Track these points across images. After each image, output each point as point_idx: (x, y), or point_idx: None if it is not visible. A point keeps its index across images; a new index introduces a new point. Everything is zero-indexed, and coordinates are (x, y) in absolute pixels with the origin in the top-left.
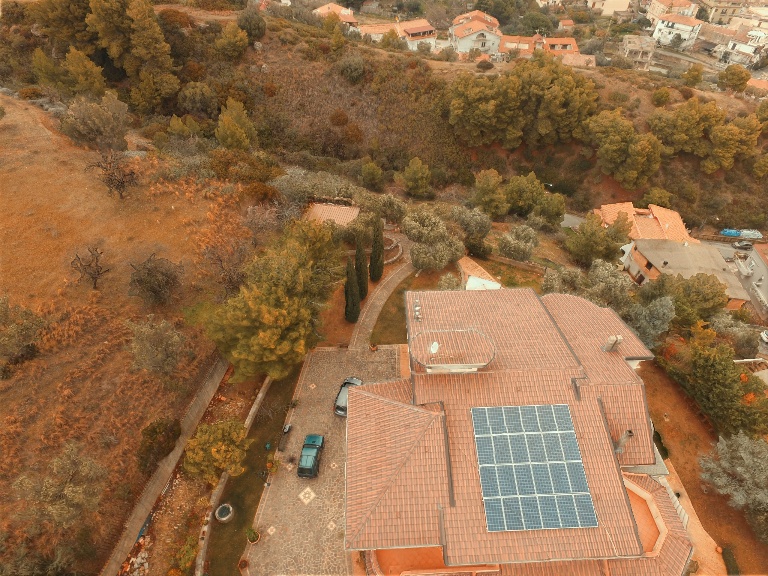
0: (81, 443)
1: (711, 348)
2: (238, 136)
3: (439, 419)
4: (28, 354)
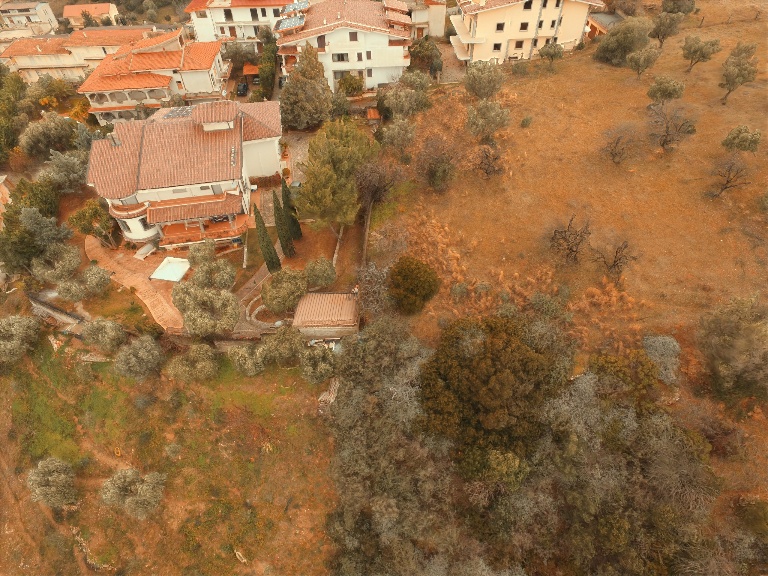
0: None
1: (23, 202)
2: None
3: None
4: (482, 142)
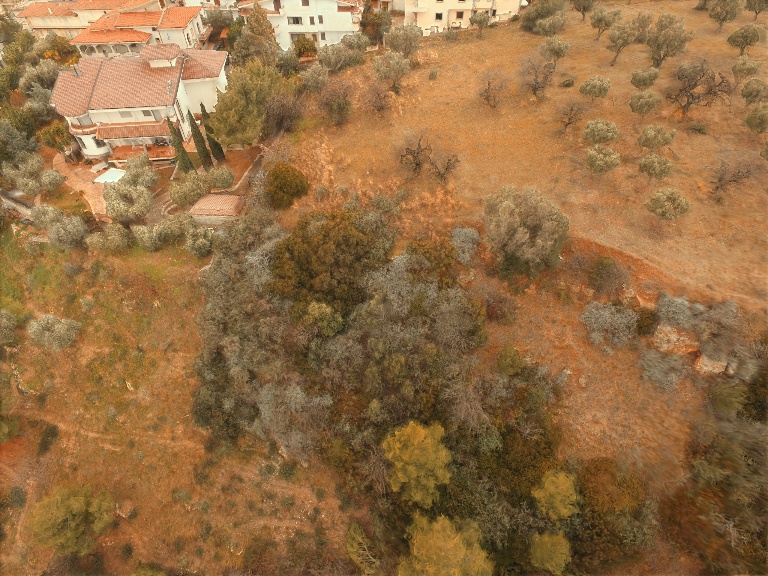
0: None
1: (2, 119)
2: None
3: None
4: None
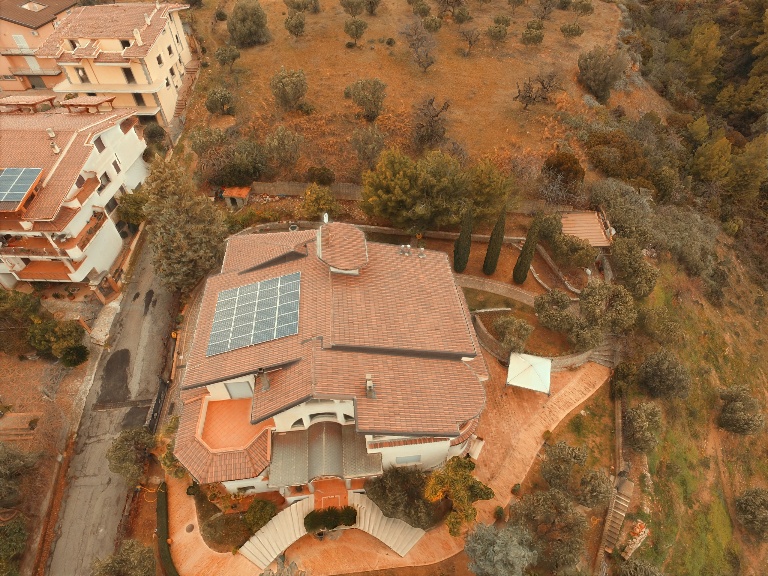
0: (322, 155)
1: None
2: (713, 162)
3: (289, 250)
4: (370, 118)
